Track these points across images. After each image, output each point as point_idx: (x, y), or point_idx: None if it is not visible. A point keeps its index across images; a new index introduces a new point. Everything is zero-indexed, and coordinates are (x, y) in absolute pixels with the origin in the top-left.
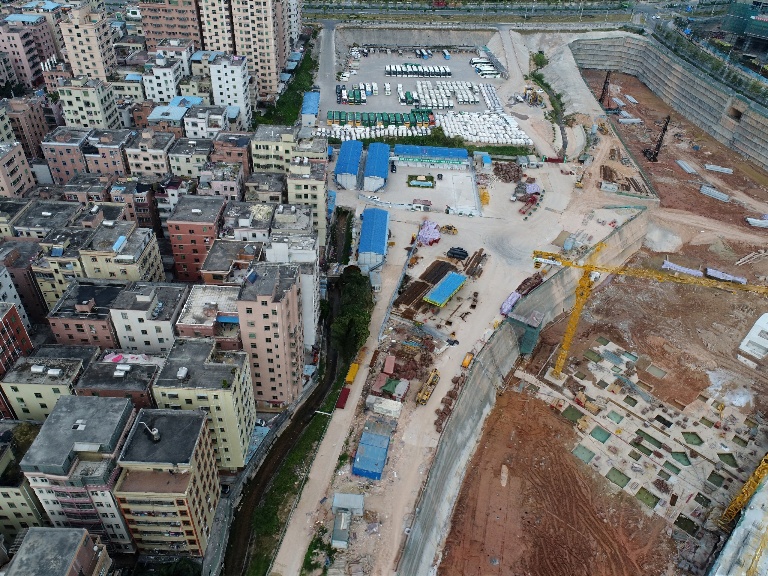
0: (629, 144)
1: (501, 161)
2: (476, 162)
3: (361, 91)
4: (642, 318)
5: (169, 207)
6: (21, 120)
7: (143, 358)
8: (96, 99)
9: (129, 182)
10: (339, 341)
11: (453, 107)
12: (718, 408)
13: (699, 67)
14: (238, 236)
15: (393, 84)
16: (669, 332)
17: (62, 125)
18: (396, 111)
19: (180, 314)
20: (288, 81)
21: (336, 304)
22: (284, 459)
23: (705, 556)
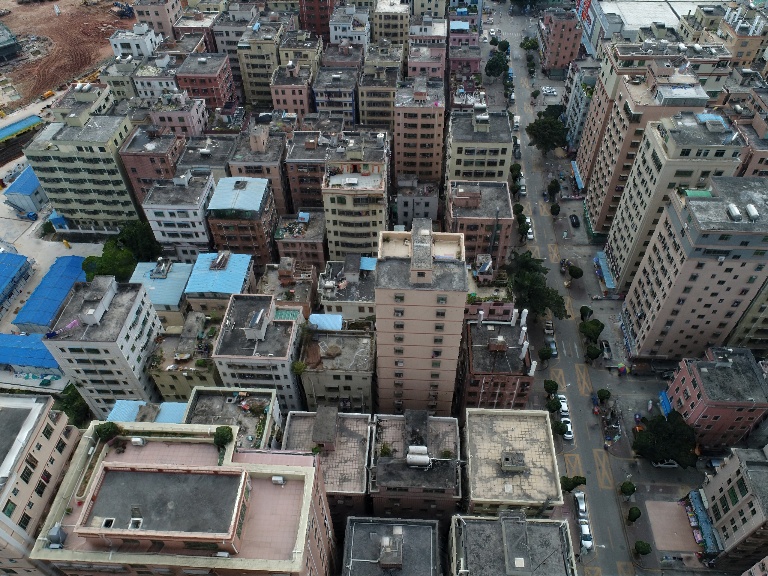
0: None
1: None
2: None
3: None
4: None
5: None
6: None
7: None
8: None
9: None
10: None
11: None
12: None
13: None
14: None
15: None
16: None
17: None
18: None
19: None
20: None
21: None
22: None
23: (2, 67)
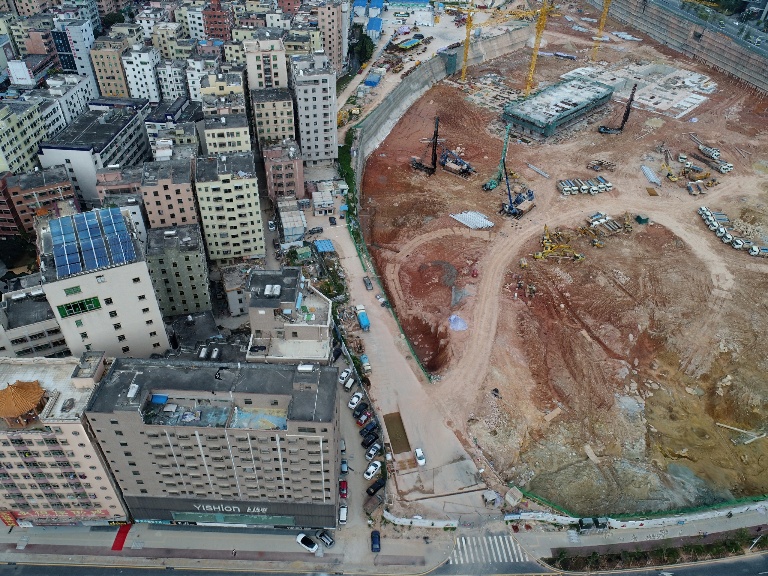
0: None
1: None
2: (434, 6)
3: None
4: (514, 67)
5: None
6: None
7: None
8: None
9: None
10: (358, 54)
11: None
12: None
13: None
14: None
15: None
16: (526, 71)
17: None
18: None
19: (292, 23)
20: None
21: None
22: None
23: None
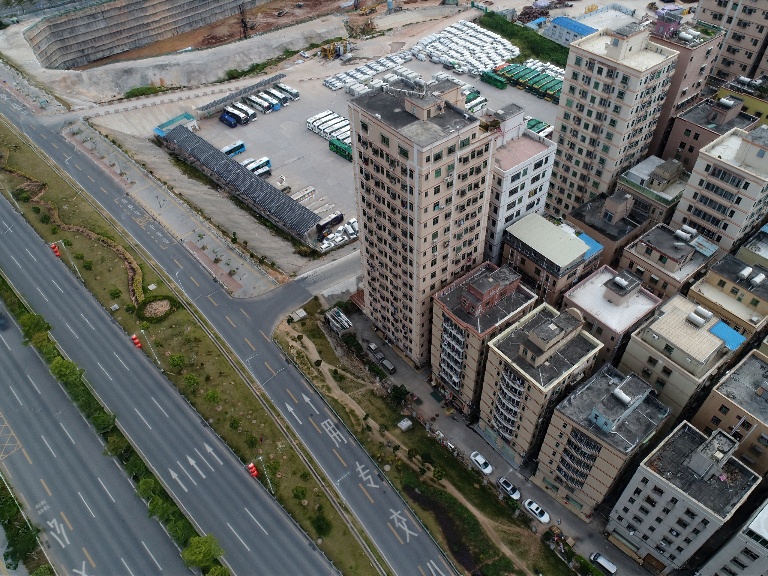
0: None
1: None
2: None
3: None
4: None
5: None
6: None
7: None
8: None
9: None
10: None
11: None
12: None
13: None
14: None
15: None
16: None
17: None
18: (508, 100)
19: None
20: None
21: None
22: None
23: None
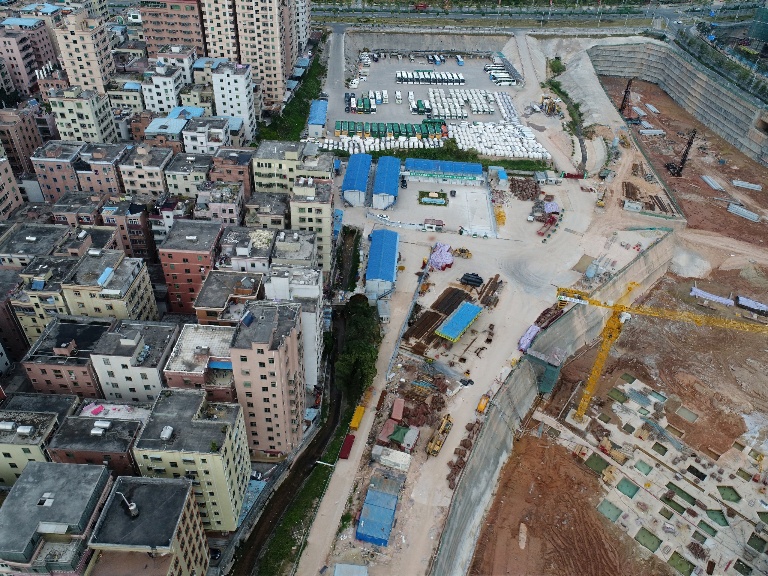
0: (651, 157)
1: (517, 176)
2: (491, 178)
3: (371, 99)
4: (670, 352)
5: (164, 229)
6: (11, 132)
7: (126, 410)
8: (90, 111)
9: (122, 202)
10: (343, 381)
11: (467, 117)
12: (756, 458)
13: (725, 76)
14: (236, 265)
15: (404, 92)
16: (700, 369)
17: (57, 136)
18: (407, 121)
19: (169, 358)
20: (295, 89)
21: (341, 335)
22: (281, 517)
23: None
